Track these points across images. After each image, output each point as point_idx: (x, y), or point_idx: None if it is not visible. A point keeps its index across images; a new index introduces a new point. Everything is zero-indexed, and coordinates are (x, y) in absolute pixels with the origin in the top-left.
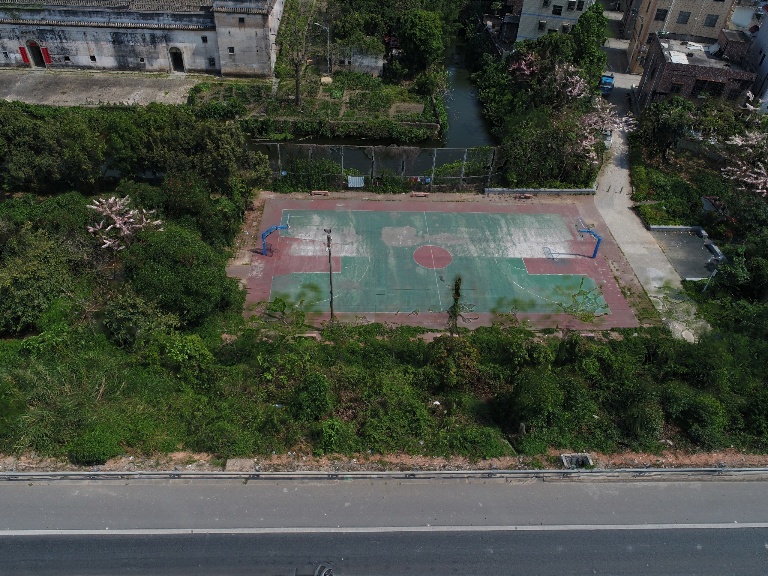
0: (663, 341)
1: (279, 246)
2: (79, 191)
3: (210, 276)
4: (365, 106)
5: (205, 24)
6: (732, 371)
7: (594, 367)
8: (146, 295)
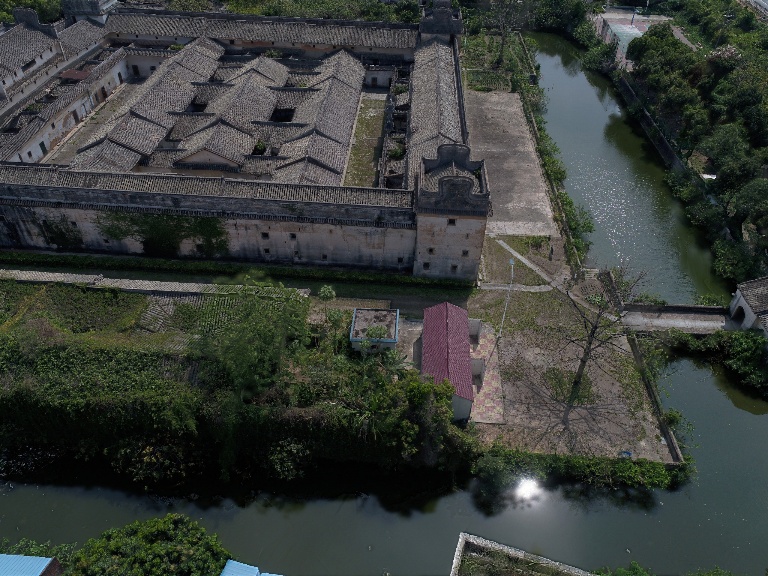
0: (699, 10)
1: None
2: None
3: None
4: None
5: None
6: None
7: None
8: None
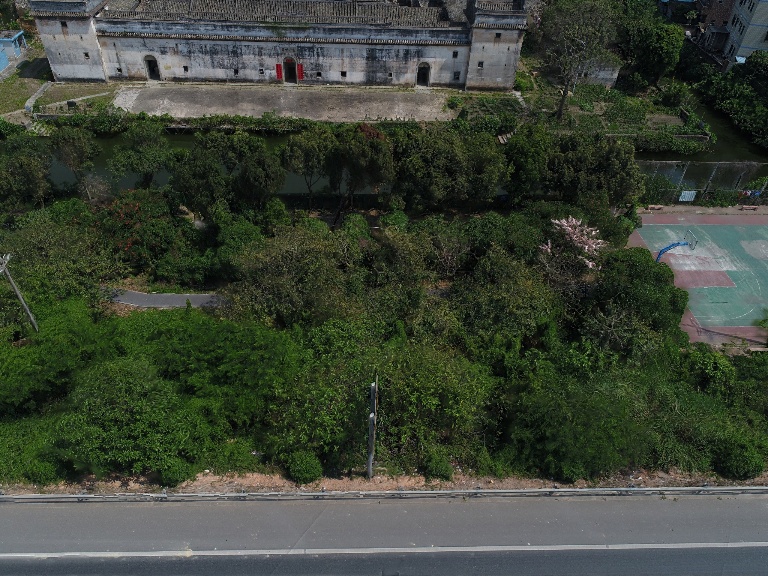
0: None
1: (660, 261)
2: (430, 208)
3: (686, 294)
4: (625, 119)
5: (460, 40)
6: None
7: None
8: (641, 313)
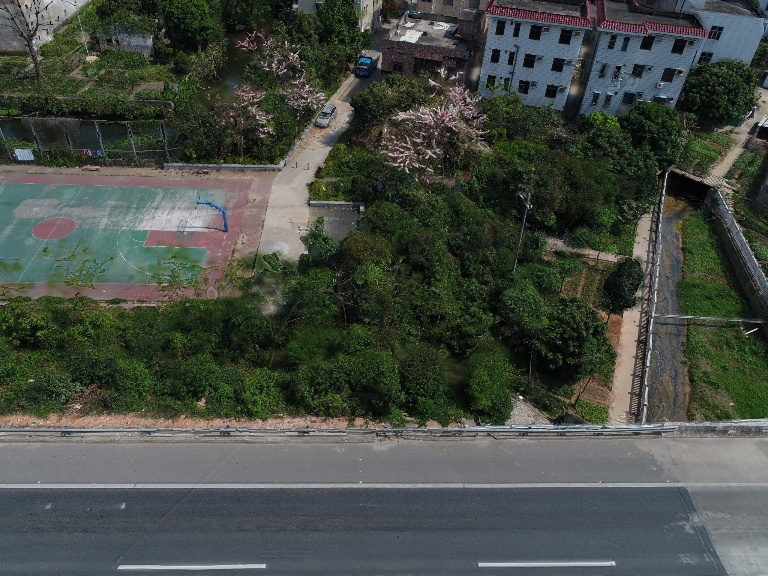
0: None
1: None
2: None
3: None
4: (109, 84)
5: None
6: (190, 336)
7: (88, 333)
8: None
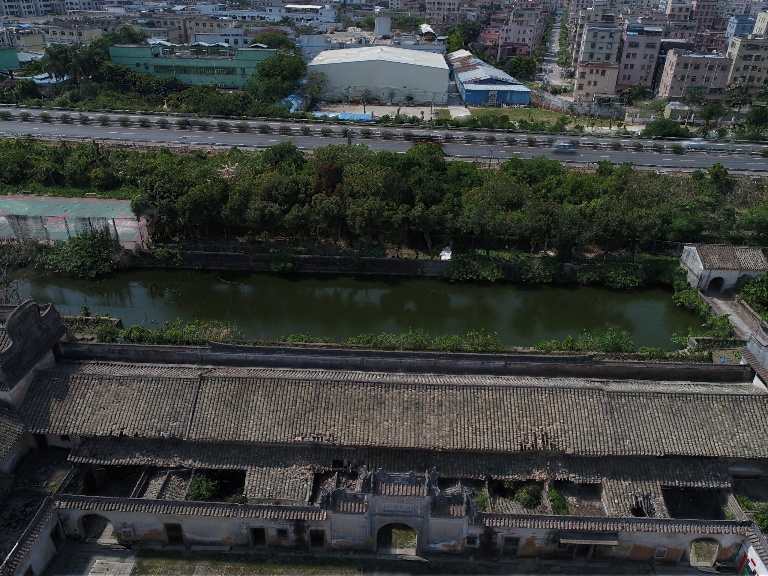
0: None
1: None
2: None
3: None
4: None
5: None
6: None
7: None
8: None
